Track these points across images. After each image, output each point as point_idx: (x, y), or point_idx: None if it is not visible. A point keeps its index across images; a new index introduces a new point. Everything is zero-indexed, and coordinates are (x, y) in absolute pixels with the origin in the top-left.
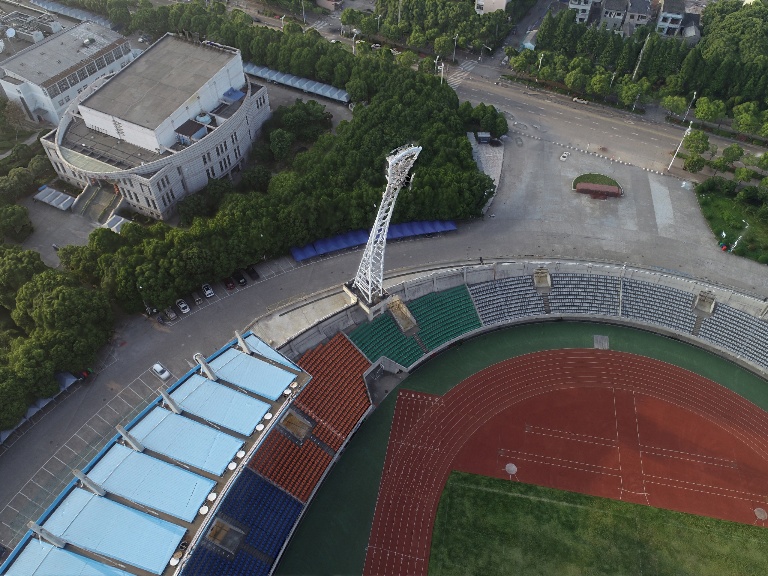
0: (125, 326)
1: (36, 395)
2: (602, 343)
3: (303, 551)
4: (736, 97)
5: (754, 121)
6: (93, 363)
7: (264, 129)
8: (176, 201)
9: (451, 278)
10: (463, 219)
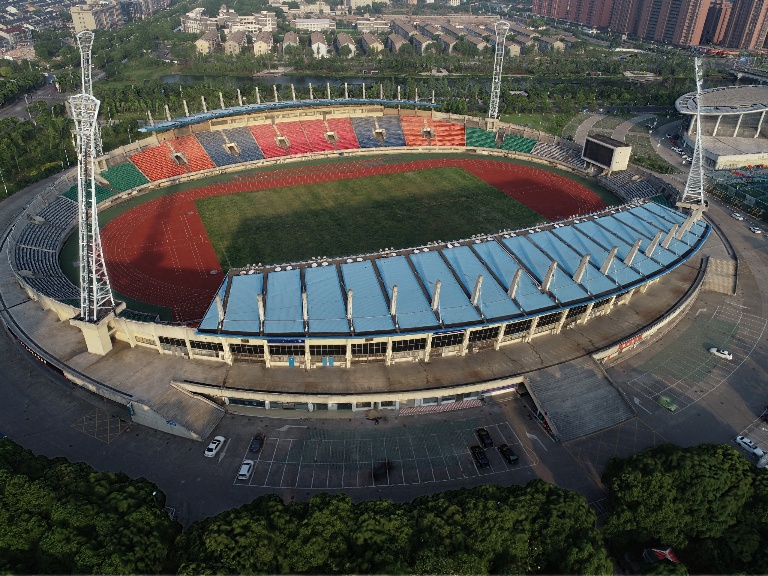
0: None
1: None
2: None
3: None
4: None
5: None
6: None
7: None
8: None
9: None
10: None
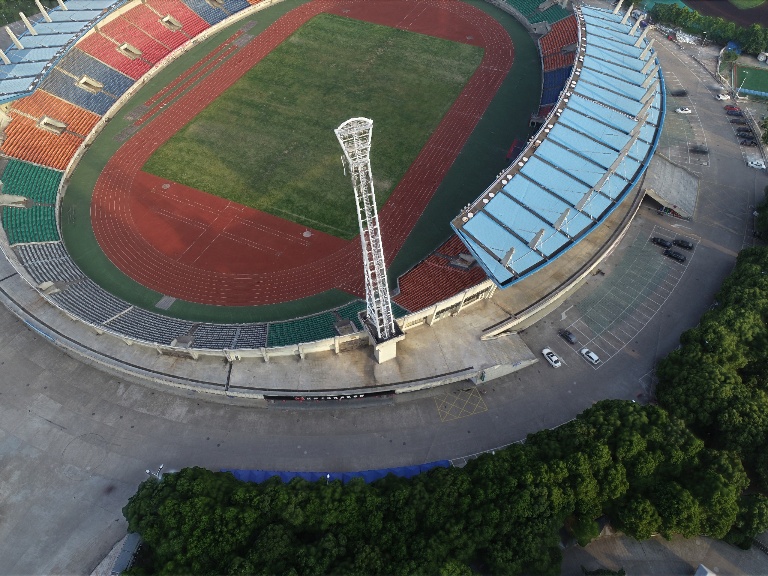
0: None
1: None
2: (166, 302)
3: None
4: None
5: None
6: None
7: None
8: None
9: None
10: None
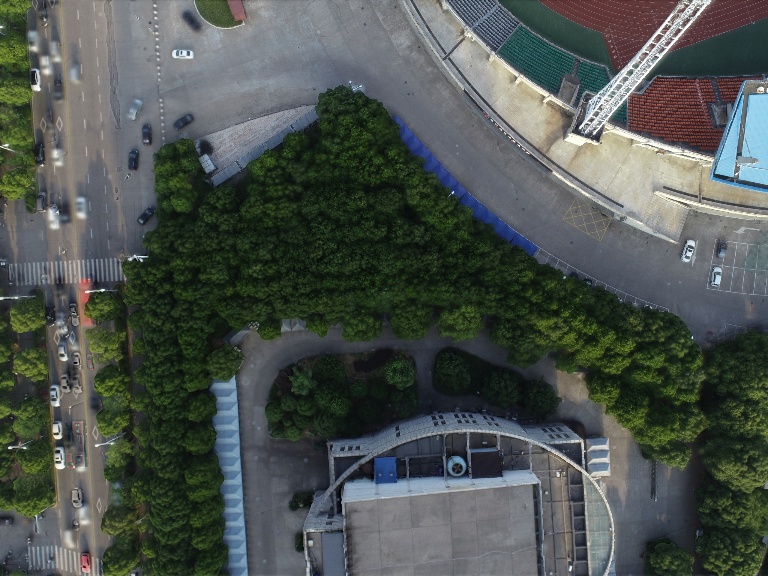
0: None
1: None
2: None
3: None
4: None
5: None
6: None
7: None
8: None
9: None
10: None
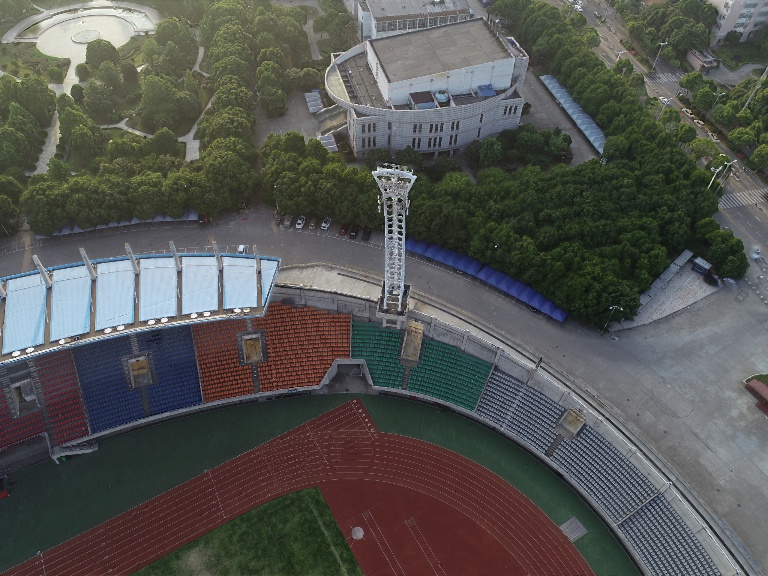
0: (258, 209)
1: (165, 210)
2: (573, 531)
3: (176, 432)
4: None
5: None
6: (213, 216)
7: None
8: None
9: (483, 348)
10: None
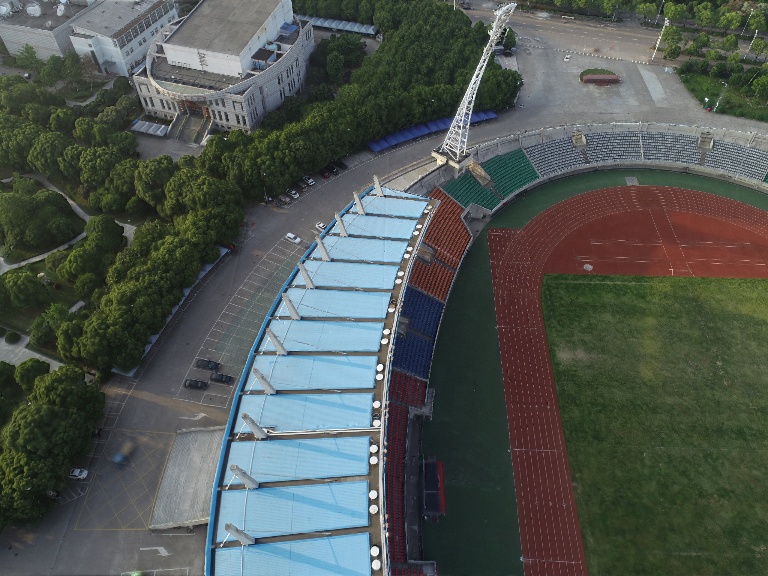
0: (249, 212)
1: (205, 259)
2: (633, 182)
3: (450, 336)
4: (693, 2)
5: (713, 15)
6: (238, 236)
7: (312, 59)
8: (258, 119)
9: (510, 143)
10: (499, 110)
